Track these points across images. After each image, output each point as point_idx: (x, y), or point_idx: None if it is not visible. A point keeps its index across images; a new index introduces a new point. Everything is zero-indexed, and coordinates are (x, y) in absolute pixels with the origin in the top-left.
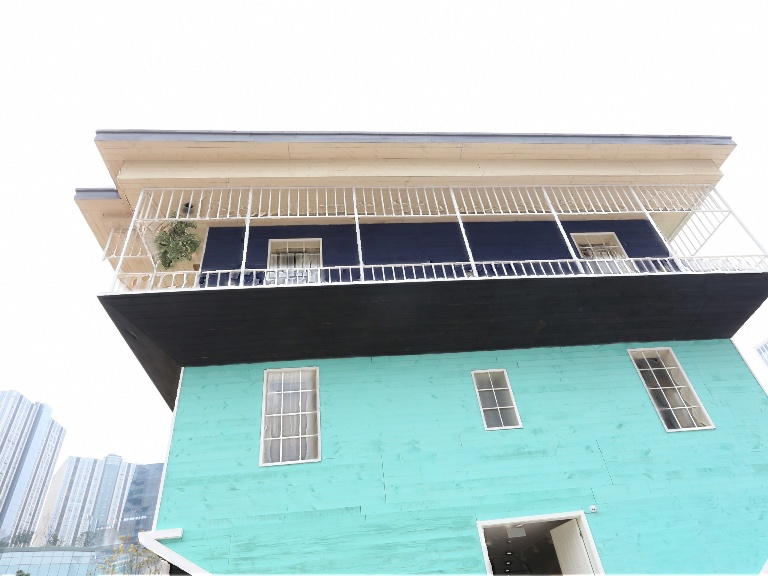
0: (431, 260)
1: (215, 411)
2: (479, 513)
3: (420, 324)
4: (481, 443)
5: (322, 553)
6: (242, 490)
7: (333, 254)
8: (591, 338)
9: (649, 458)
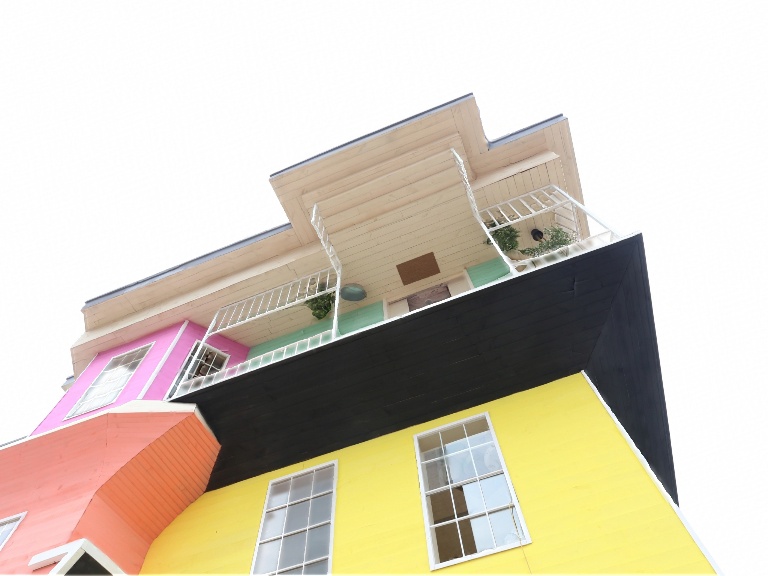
0: None
1: None
2: None
3: None
4: None
5: None
6: None
7: None
8: None
9: None
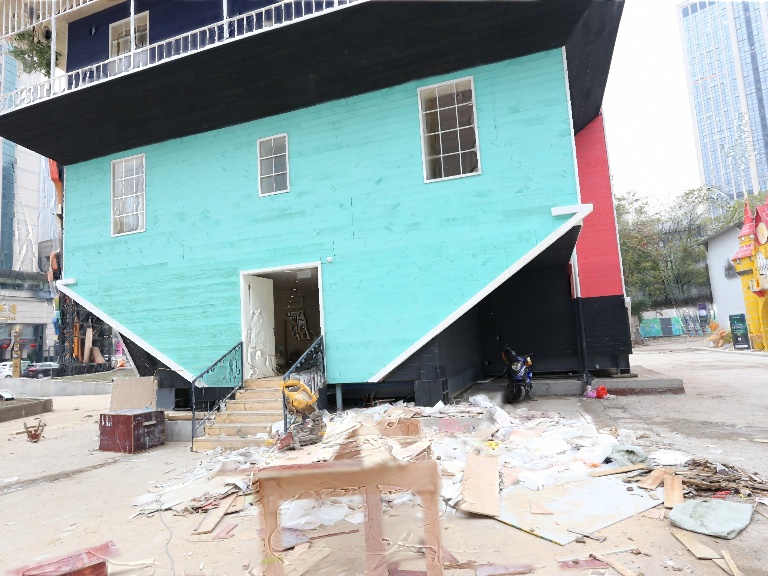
0: (240, 11)
1: (85, 198)
2: (243, 265)
3: (200, 101)
4: (254, 209)
5: (146, 292)
6: (103, 253)
7: (158, 28)
8: (375, 82)
9: (395, 212)
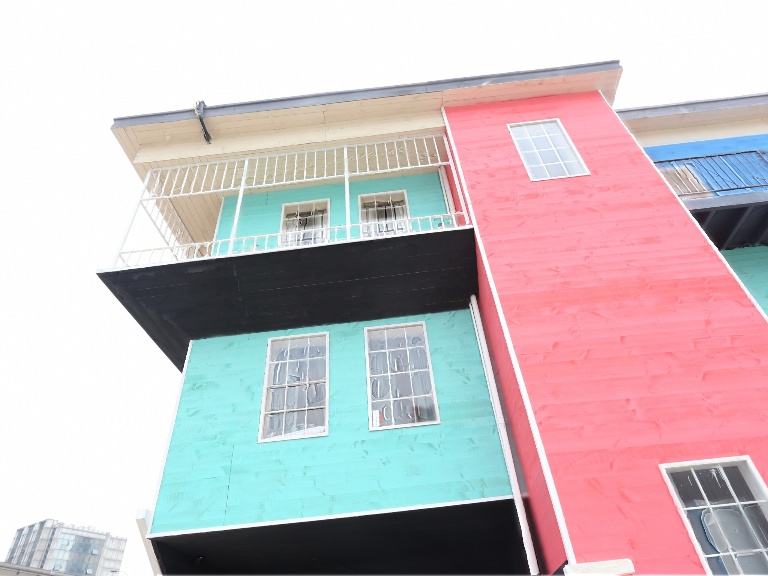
0: None
1: None
2: None
3: None
4: None
5: None
6: None
7: None
8: None
9: None
